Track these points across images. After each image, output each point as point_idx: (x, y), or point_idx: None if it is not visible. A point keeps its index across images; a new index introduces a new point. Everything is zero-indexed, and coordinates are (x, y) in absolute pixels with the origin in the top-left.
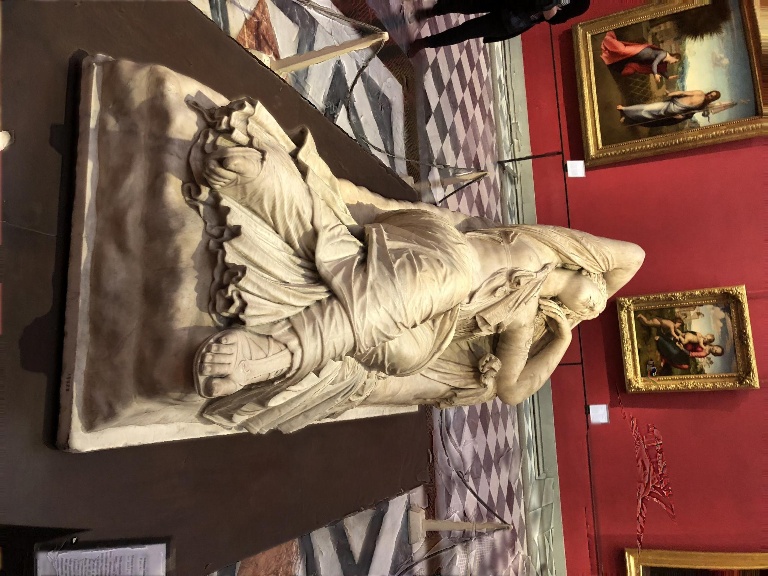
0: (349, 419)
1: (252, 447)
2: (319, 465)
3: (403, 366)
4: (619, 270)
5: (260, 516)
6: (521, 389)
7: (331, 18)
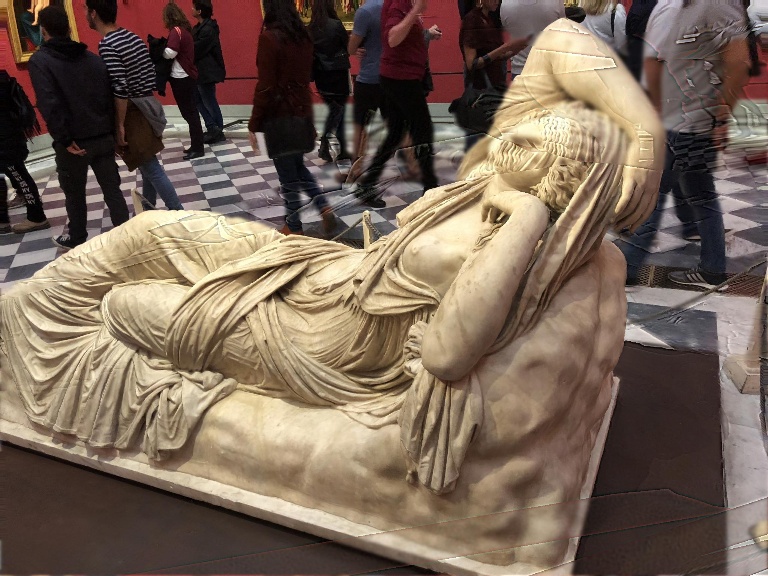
0: (254, 507)
1: (96, 492)
2: (182, 557)
3: (113, 308)
4: (554, 70)
5: (41, 546)
6: (430, 324)
7: (338, 239)
